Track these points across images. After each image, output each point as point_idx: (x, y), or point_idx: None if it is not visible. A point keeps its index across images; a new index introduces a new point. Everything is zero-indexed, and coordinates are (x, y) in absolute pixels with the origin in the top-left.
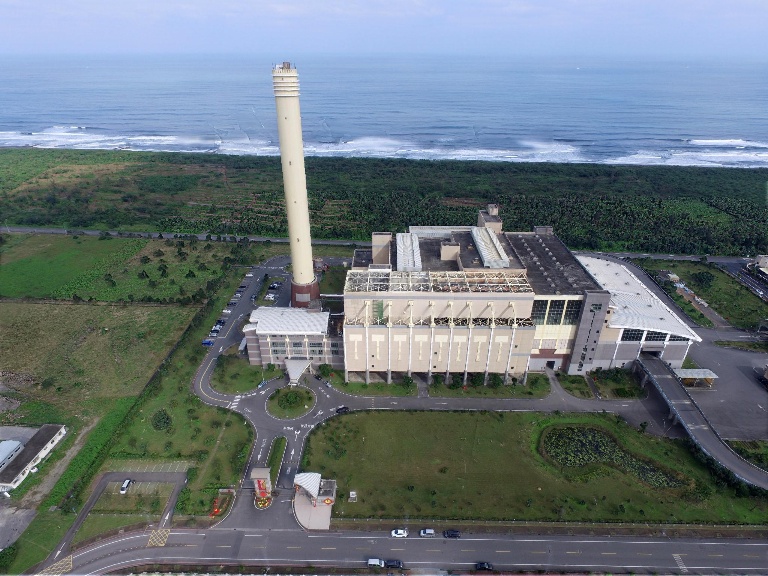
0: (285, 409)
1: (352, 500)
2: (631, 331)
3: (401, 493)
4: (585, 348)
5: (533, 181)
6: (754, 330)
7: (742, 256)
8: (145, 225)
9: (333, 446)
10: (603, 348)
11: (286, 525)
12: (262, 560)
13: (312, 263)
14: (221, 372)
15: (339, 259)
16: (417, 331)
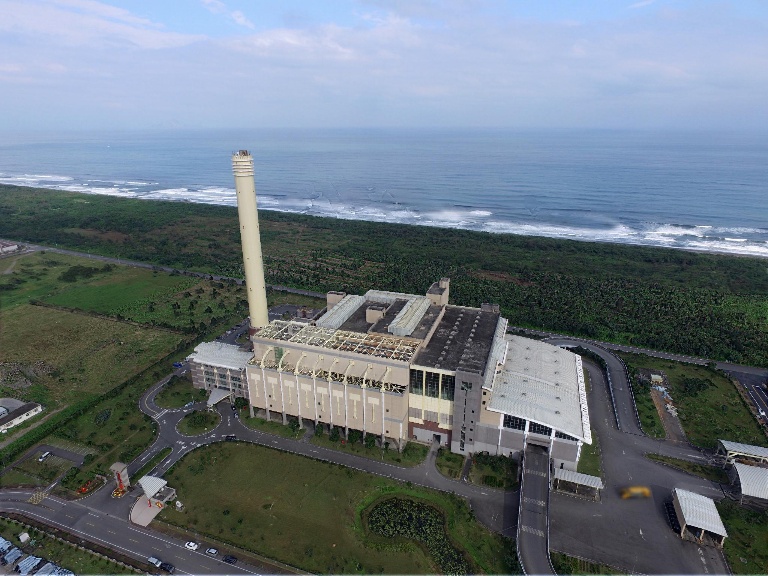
0: (189, 427)
1: (179, 509)
2: (512, 418)
3: (219, 515)
4: (463, 427)
5: (585, 261)
6: (713, 452)
7: None
8: (208, 268)
9: None
10: (486, 431)
11: (120, 514)
12: (85, 534)
13: (266, 311)
14: None
15: None
16: (302, 380)
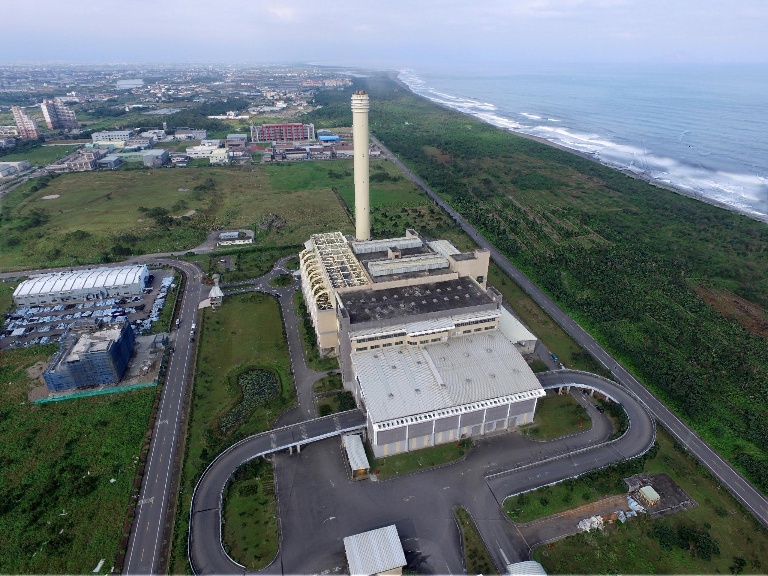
0: None
1: None
2: None
3: None
4: None
5: None
6: None
7: None
8: (450, 196)
9: None
10: None
11: None
12: None
13: (365, 228)
14: None
15: None
16: None
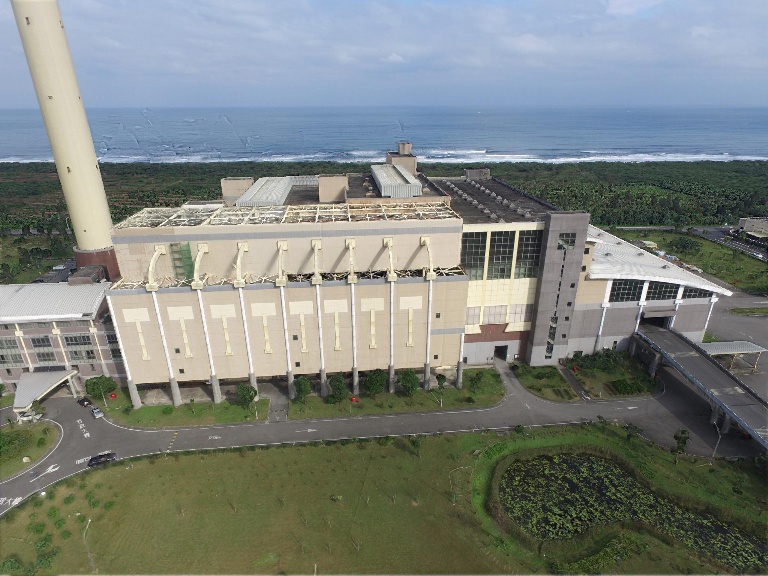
0: None
1: None
2: (624, 284)
3: None
4: (554, 317)
5: None
6: None
7: (719, 224)
8: None
9: None
10: (582, 317)
11: None
12: None
13: (108, 216)
14: None
15: None
16: (253, 295)
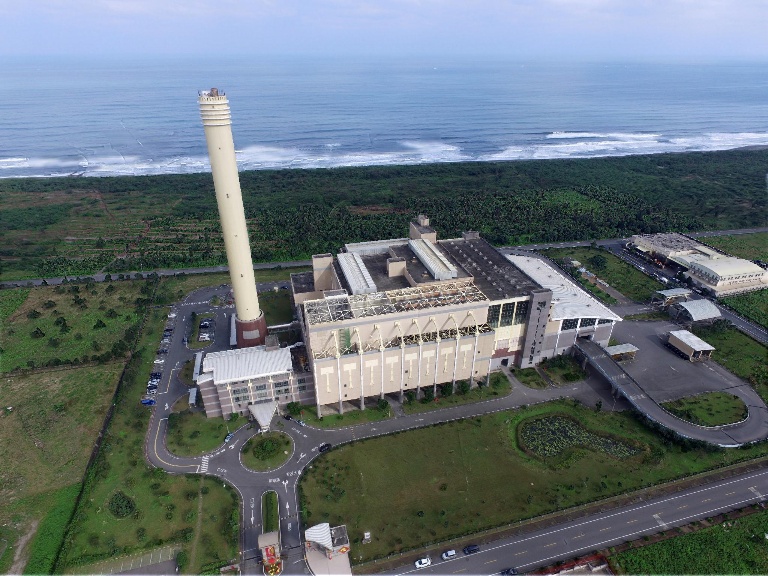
0: (264, 460)
1: (366, 541)
2: (568, 321)
3: (411, 521)
4: (534, 343)
5: (430, 183)
6: (648, 302)
7: (619, 237)
8: (18, 271)
9: (328, 489)
10: (547, 340)
11: None
12: None
13: None
14: (176, 433)
15: (267, 284)
16: (388, 354)
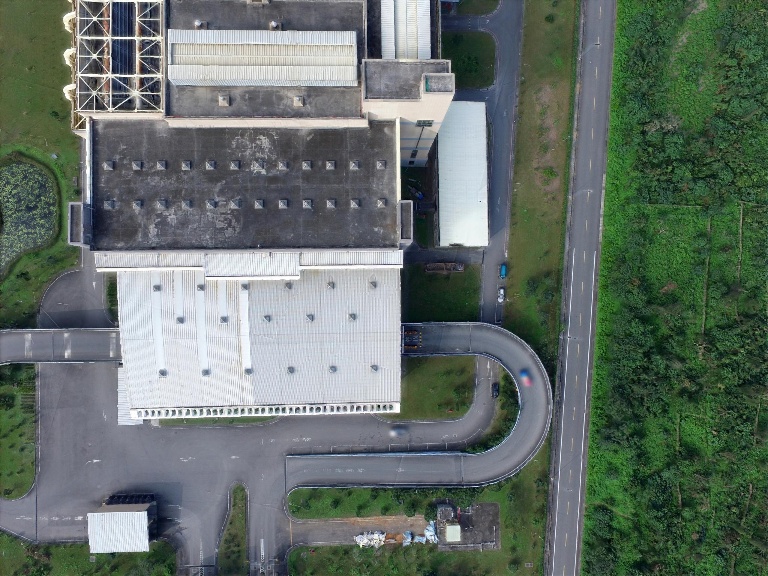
0: None
1: None
2: None
3: None
4: None
5: None
6: (281, 575)
7: None
8: None
9: None
10: None
11: None
12: None
13: None
14: None
15: None
16: None
